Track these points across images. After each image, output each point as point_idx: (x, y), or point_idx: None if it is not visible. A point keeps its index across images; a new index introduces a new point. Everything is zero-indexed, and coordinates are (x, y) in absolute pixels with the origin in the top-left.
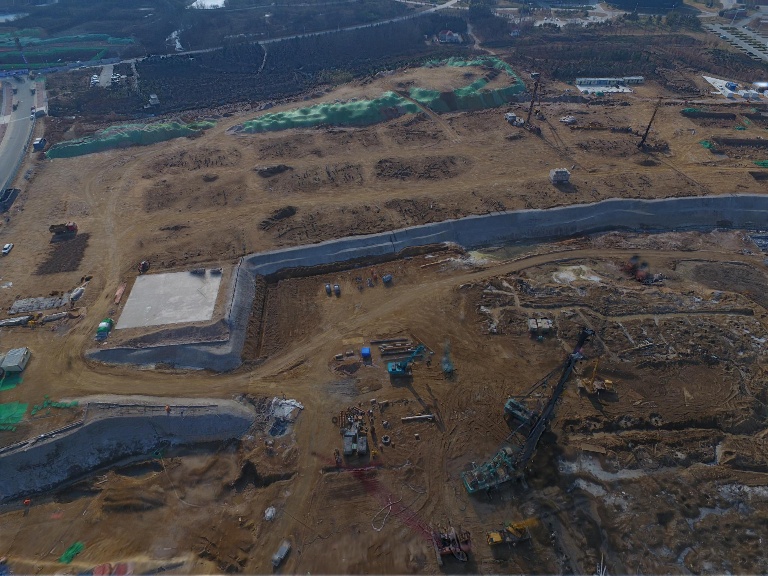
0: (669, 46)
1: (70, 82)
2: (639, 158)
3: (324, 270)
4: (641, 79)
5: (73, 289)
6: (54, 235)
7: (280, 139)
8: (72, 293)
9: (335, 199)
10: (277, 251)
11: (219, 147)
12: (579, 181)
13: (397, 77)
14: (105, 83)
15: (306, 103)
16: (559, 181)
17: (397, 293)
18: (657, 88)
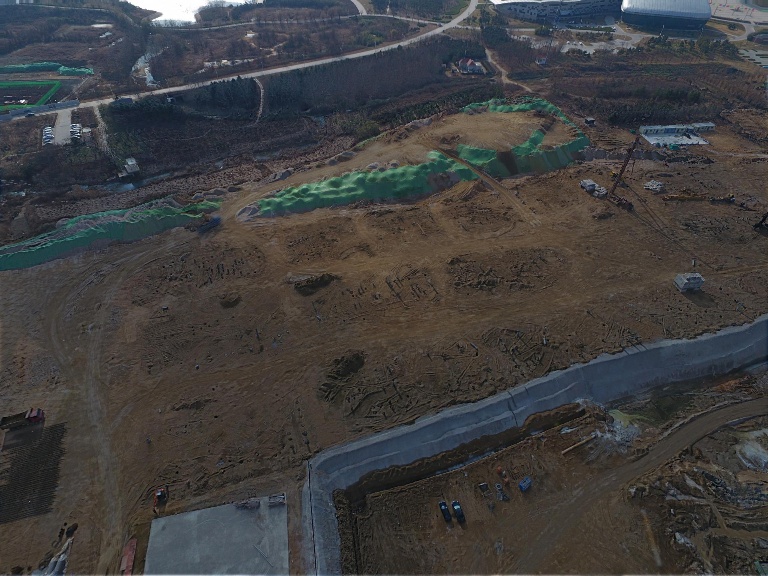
0: (720, 81)
1: (14, 138)
2: (763, 245)
3: (428, 470)
4: (712, 126)
5: (47, 560)
6: (8, 432)
7: (311, 226)
8: (46, 571)
9: (412, 333)
10: (357, 445)
11: (232, 243)
12: (711, 286)
13: (436, 128)
14: (63, 140)
15: (333, 169)
16: (689, 289)
17: (547, 513)
18: (733, 138)
